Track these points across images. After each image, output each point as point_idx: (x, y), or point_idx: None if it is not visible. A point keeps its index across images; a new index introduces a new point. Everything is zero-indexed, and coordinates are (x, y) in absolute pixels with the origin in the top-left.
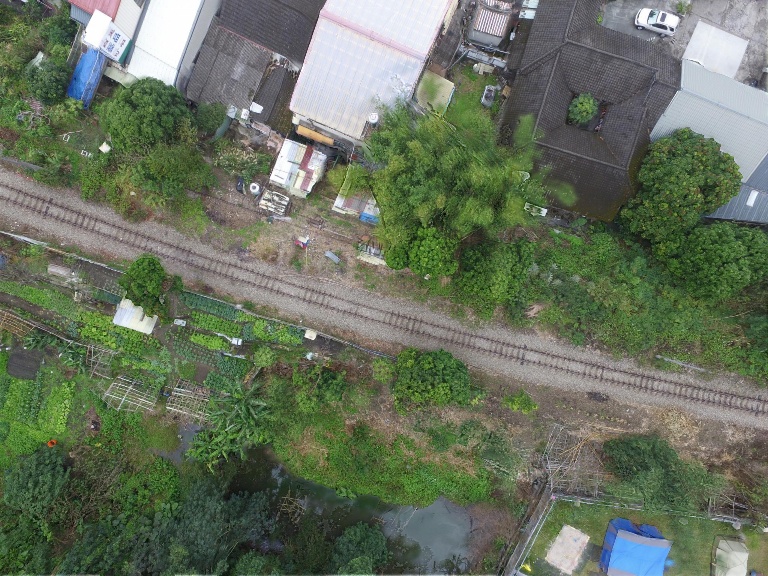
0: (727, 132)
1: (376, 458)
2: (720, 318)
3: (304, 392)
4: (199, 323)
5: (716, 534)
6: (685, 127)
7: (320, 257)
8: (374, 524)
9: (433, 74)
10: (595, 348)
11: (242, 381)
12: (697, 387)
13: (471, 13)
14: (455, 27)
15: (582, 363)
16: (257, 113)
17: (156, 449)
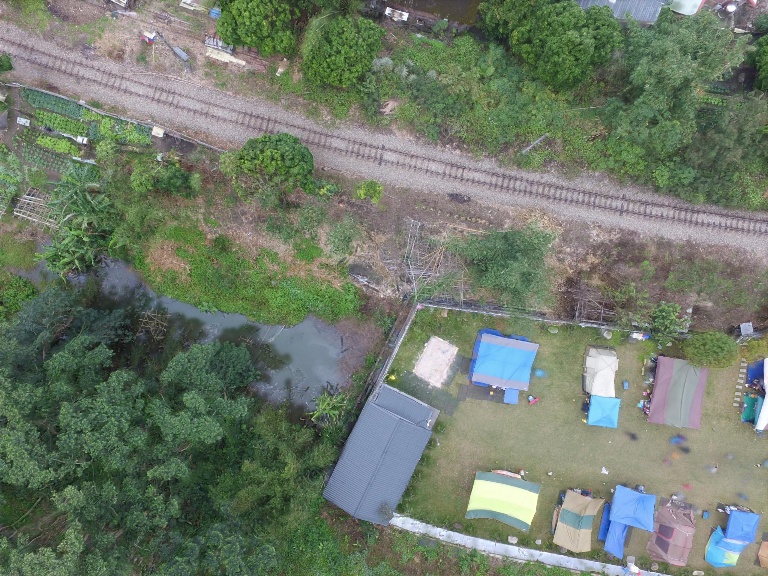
0: None
1: (239, 272)
2: (579, 111)
3: (137, 170)
4: (43, 122)
5: (587, 344)
6: None
7: (168, 54)
8: (241, 343)
9: None
10: (455, 148)
11: None
12: (560, 186)
13: None
14: None
15: (441, 162)
16: None
17: (13, 267)
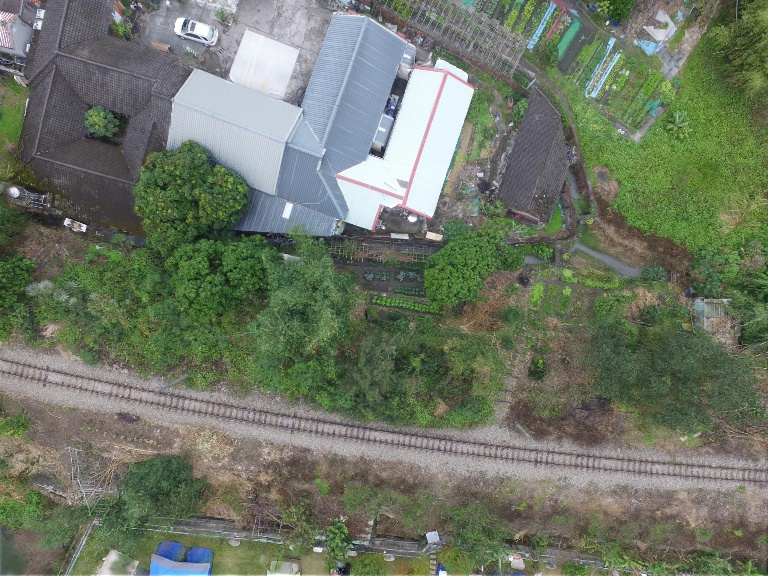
0: (235, 144)
1: None
2: (241, 334)
3: None
4: None
5: (272, 555)
6: None
7: None
8: None
9: None
10: (122, 367)
11: None
12: (230, 405)
13: None
14: None
15: (107, 383)
16: None
17: None
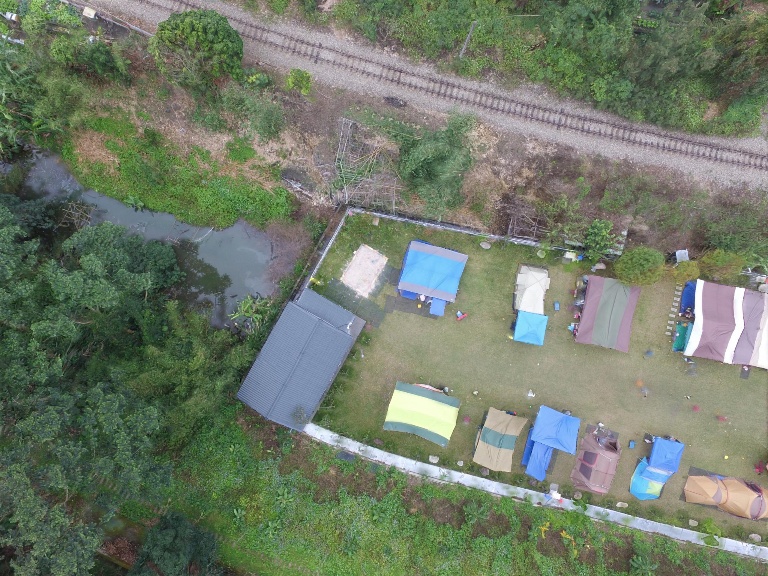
0: None
1: (169, 168)
2: None
3: None
4: None
5: (520, 262)
6: None
7: None
8: (167, 243)
9: None
10: (393, 51)
11: None
12: (498, 96)
13: None
14: None
15: (378, 64)
16: None
17: None
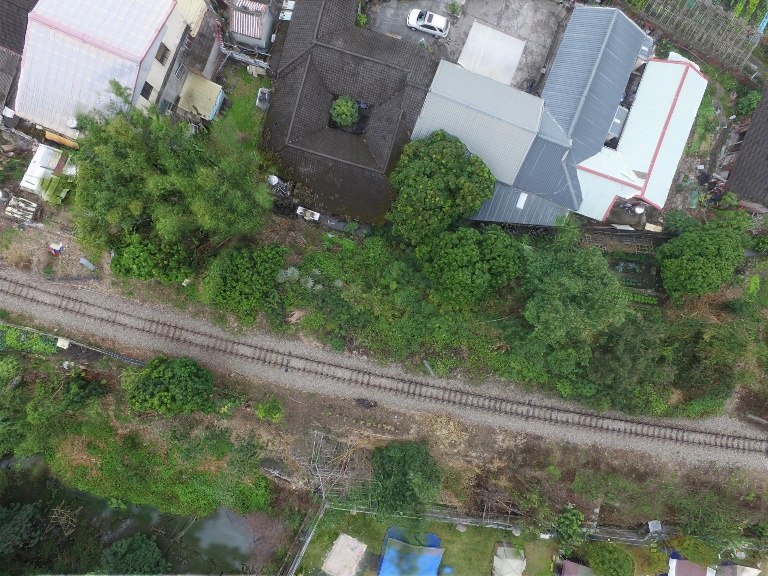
0: (483, 134)
1: (149, 468)
2: (483, 322)
3: (31, 403)
4: None
5: (496, 541)
6: (439, 129)
7: (75, 264)
8: (152, 535)
9: (198, 77)
10: (362, 354)
11: (3, 391)
12: (466, 392)
13: (223, 15)
14: (207, 29)
15: (348, 369)
16: (9, 118)
17: None
